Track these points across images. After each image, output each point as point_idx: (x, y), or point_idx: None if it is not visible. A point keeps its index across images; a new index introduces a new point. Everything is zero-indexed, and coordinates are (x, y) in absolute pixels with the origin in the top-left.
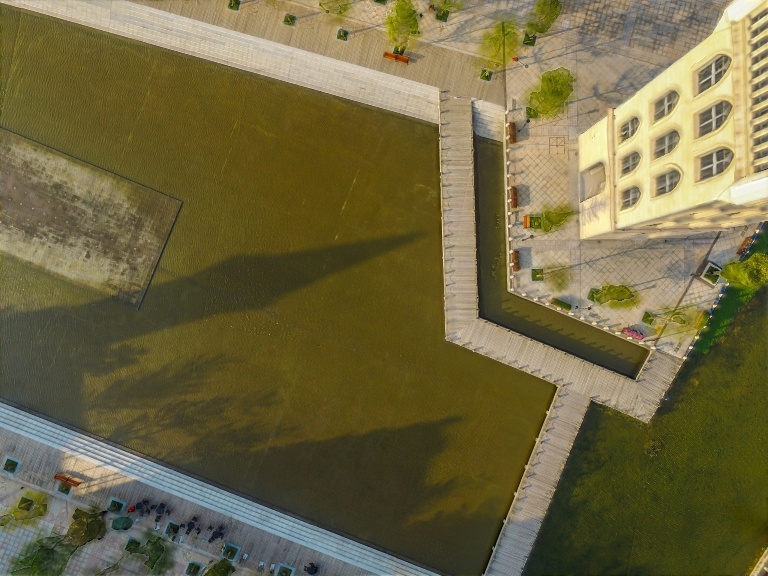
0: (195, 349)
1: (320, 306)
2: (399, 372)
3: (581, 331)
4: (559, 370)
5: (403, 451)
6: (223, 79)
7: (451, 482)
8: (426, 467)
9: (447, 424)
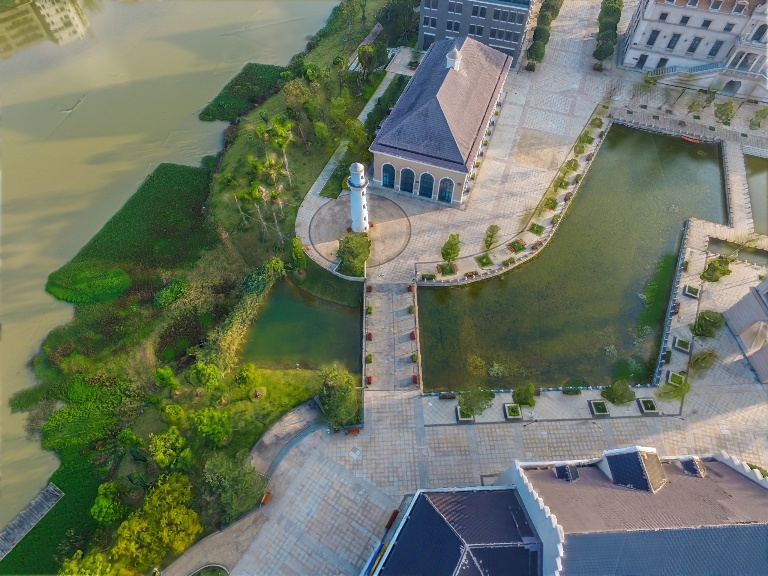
0: None
1: None
2: None
3: None
4: (761, 240)
5: None
6: None
7: None
8: None
9: None
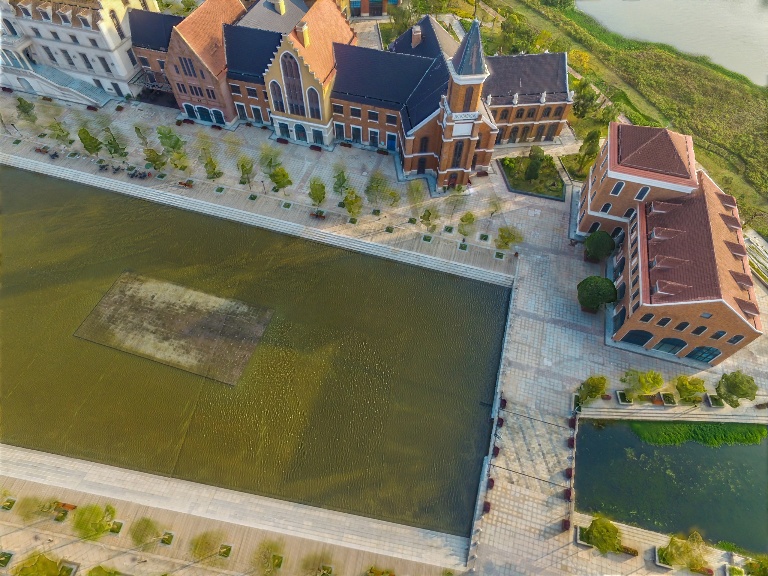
0: (94, 251)
1: None
2: None
3: None
4: None
5: None
6: (6, 431)
7: None
8: None
9: None
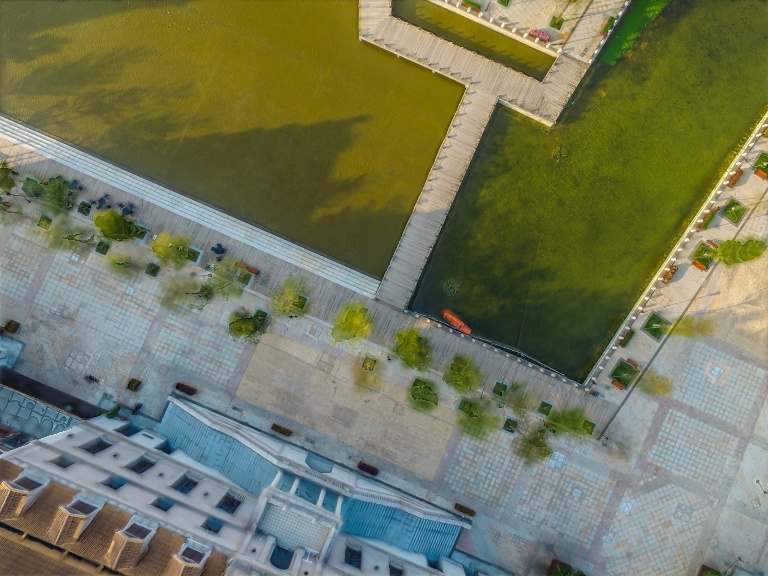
0: (116, 41)
1: (239, 5)
2: (314, 70)
3: (492, 39)
4: (468, 69)
5: (315, 146)
6: None
7: (361, 178)
8: (337, 163)
9: (359, 122)
